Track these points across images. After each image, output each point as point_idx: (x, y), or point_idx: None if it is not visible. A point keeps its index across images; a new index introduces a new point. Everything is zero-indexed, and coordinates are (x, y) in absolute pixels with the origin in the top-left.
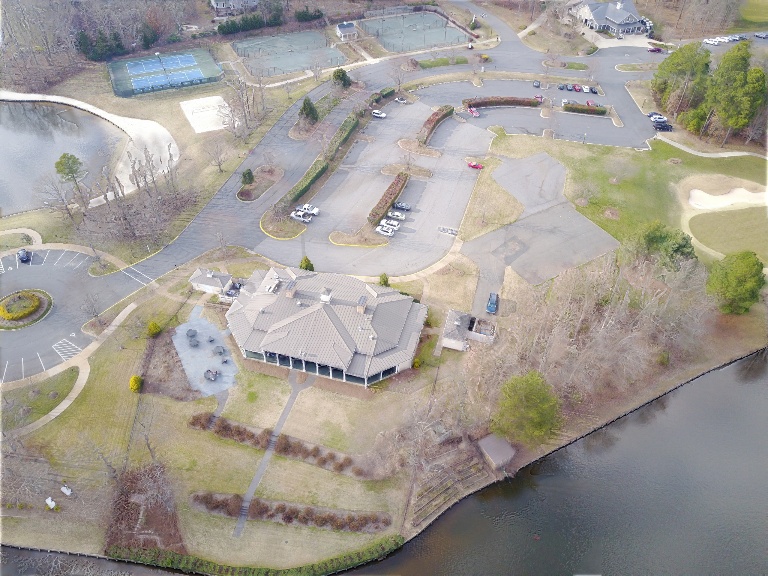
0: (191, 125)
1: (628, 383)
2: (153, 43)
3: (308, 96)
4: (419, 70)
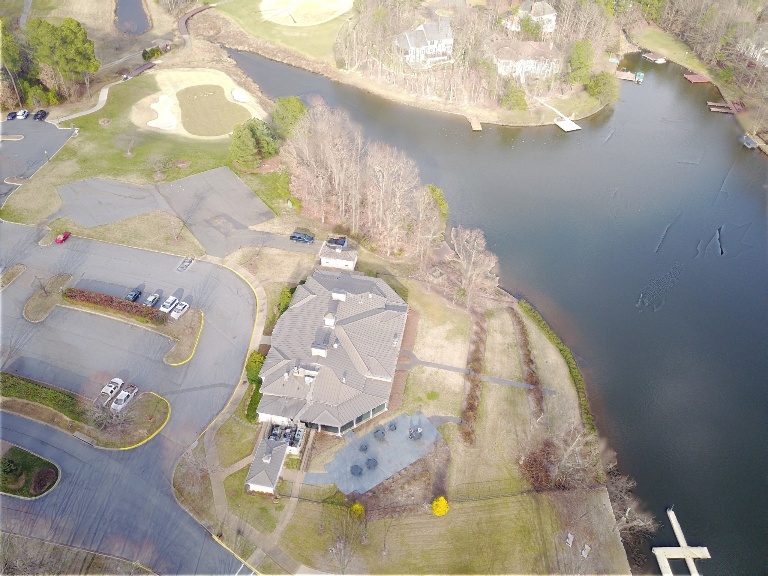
0: None
1: None
2: None
3: None
4: None
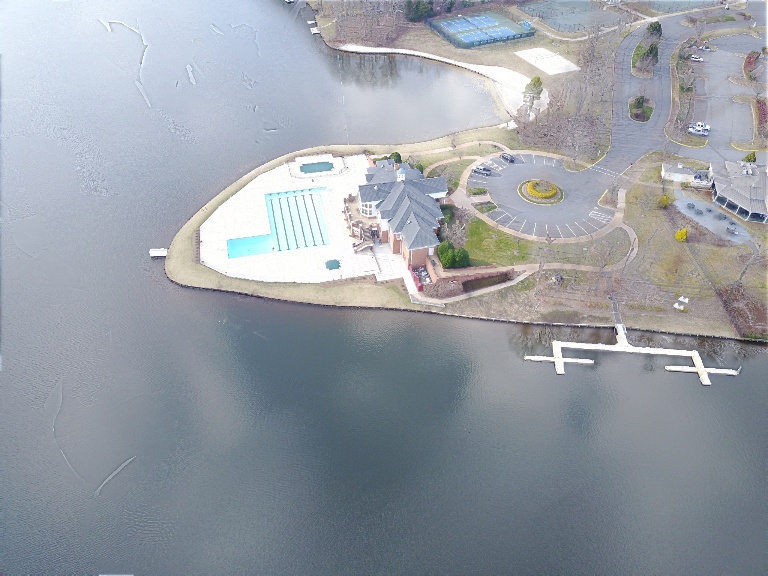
0: (540, 69)
1: None
2: (453, 7)
3: (623, 46)
4: None
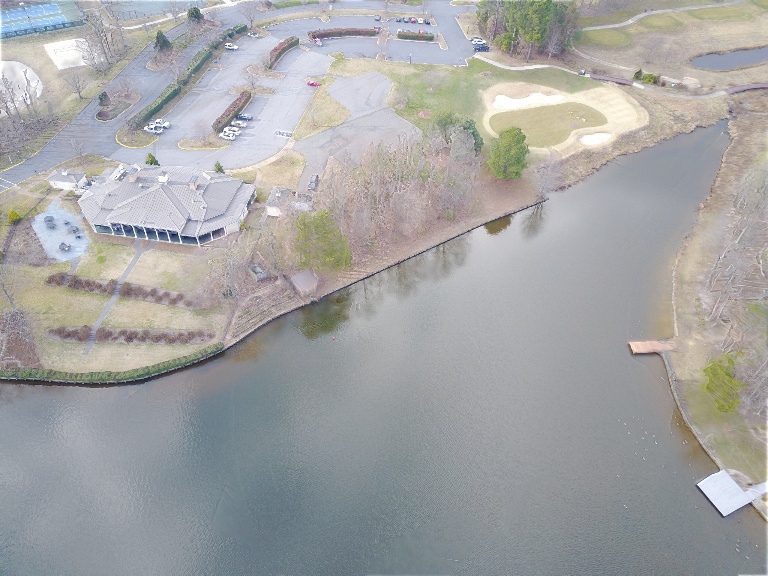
0: (54, 63)
1: (411, 227)
2: None
3: (167, 34)
4: (273, 10)
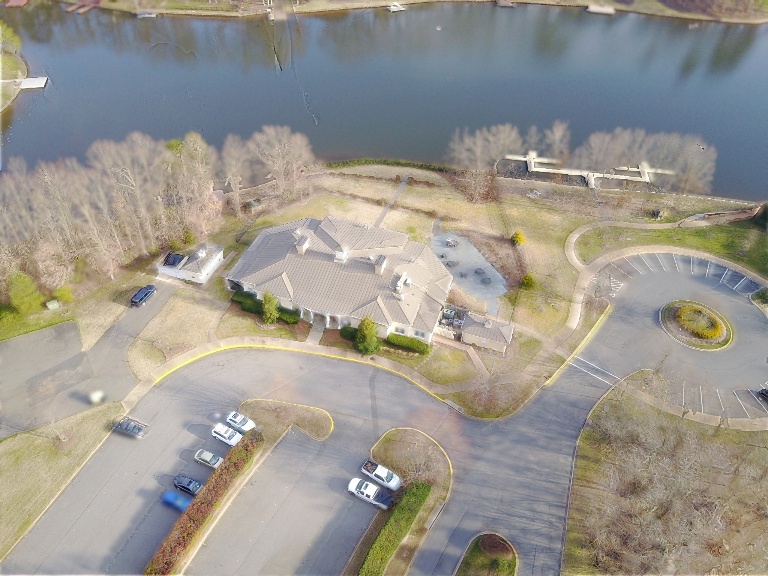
0: None
1: None
2: None
3: None
4: None
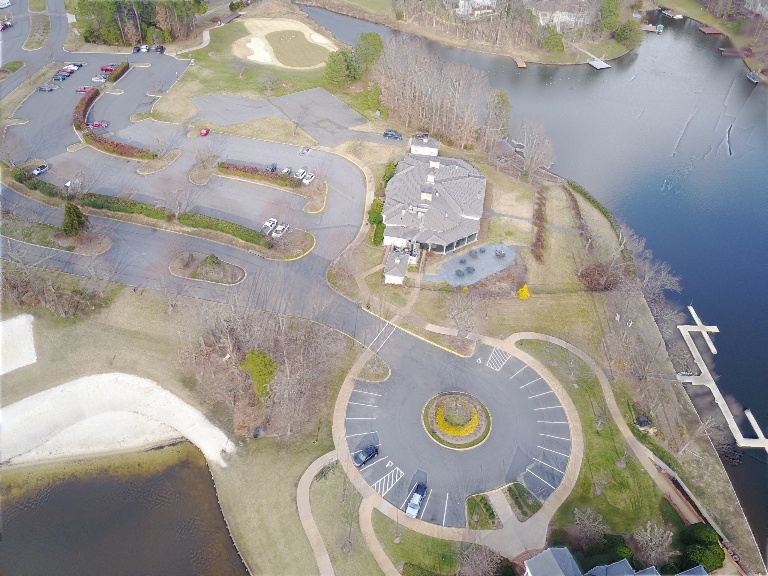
0: (3, 374)
1: None
2: None
3: None
4: None
